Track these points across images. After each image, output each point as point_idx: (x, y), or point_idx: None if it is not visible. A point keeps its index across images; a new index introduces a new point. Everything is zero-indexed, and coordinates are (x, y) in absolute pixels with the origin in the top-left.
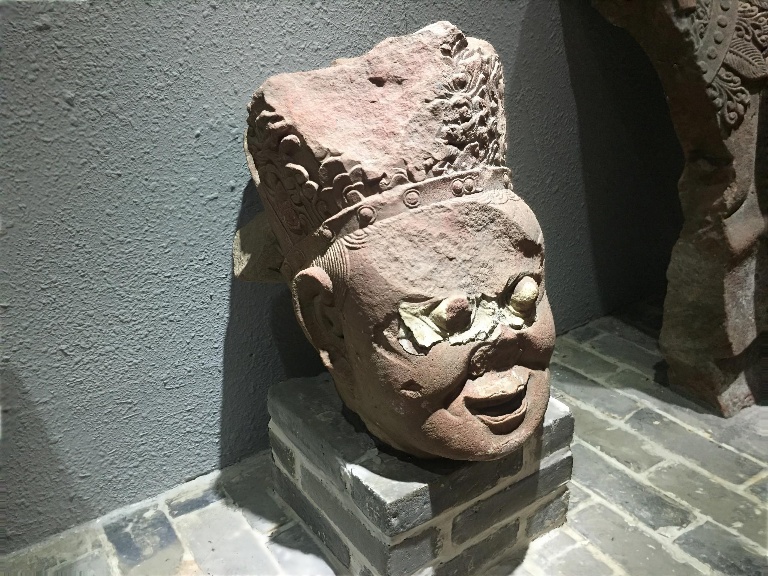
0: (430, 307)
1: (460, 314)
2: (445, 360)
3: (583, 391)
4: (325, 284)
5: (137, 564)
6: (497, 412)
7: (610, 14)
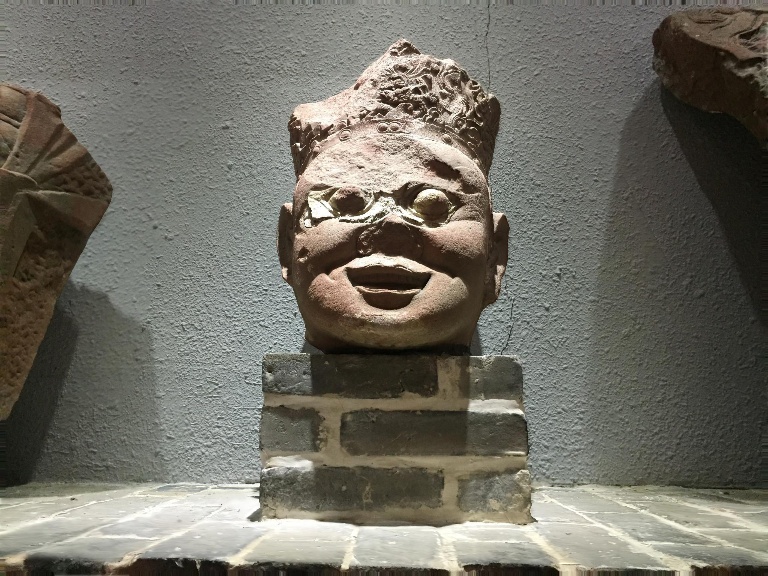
0: (329, 194)
1: (352, 198)
2: (329, 229)
3: (710, 501)
4: (288, 208)
5: (157, 491)
6: (377, 287)
7: (702, 103)
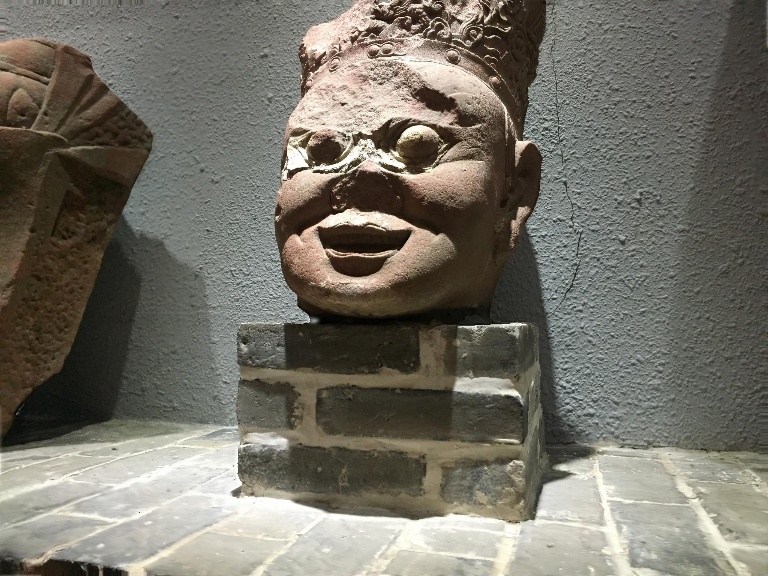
0: (307, 139)
1: (327, 144)
2: (301, 183)
3: None
4: None
5: (201, 439)
6: (347, 250)
7: None
